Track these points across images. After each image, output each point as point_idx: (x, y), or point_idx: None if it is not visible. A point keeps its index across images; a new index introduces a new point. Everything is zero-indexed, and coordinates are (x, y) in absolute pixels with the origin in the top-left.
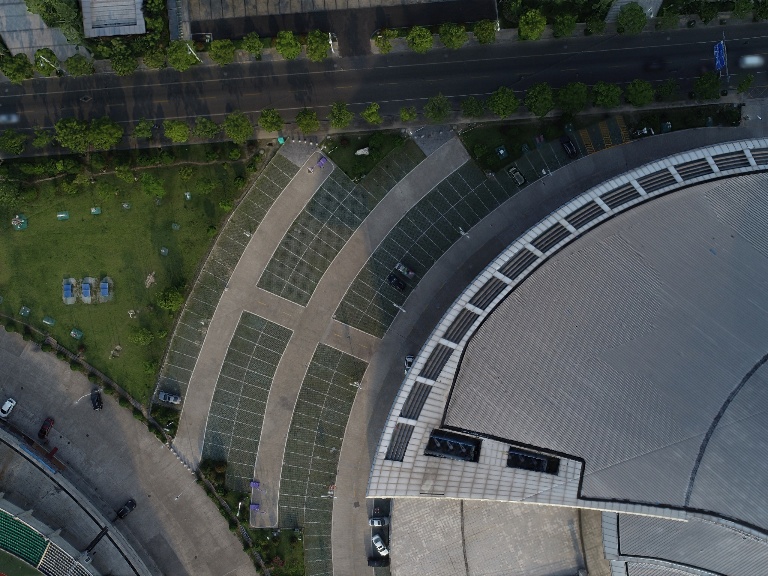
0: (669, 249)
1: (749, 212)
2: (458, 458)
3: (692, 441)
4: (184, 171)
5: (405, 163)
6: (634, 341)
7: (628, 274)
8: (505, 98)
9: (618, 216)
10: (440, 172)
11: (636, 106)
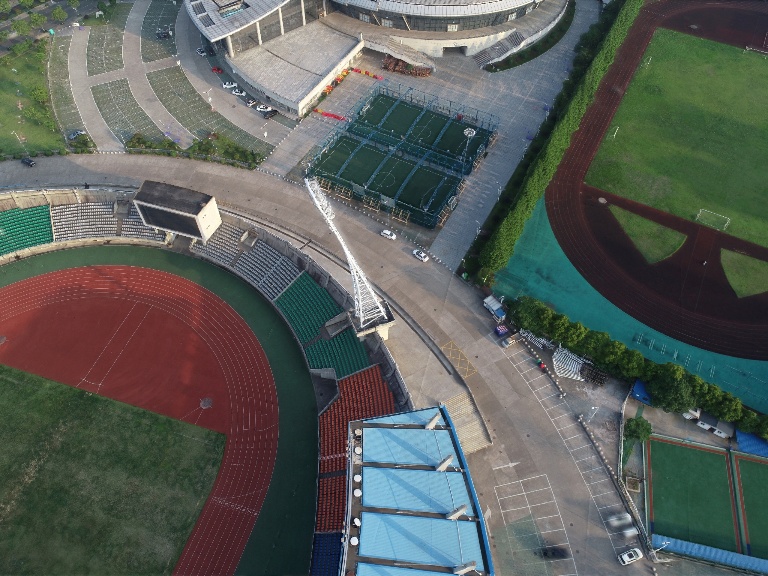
0: None
1: None
2: None
3: None
4: (4, 58)
5: (125, 10)
6: None
7: None
8: None
9: None
10: (146, 4)
11: None
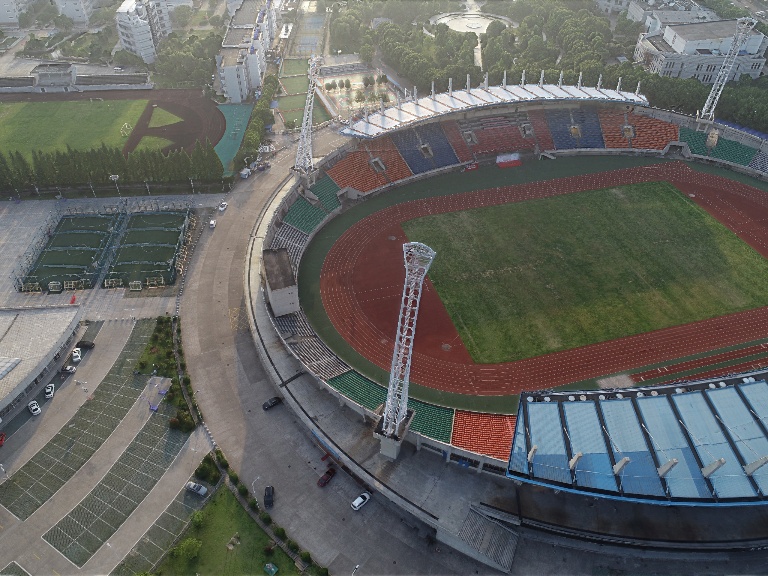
0: None
1: None
2: None
3: None
4: None
5: None
6: None
7: None
8: None
9: None
10: None
11: None
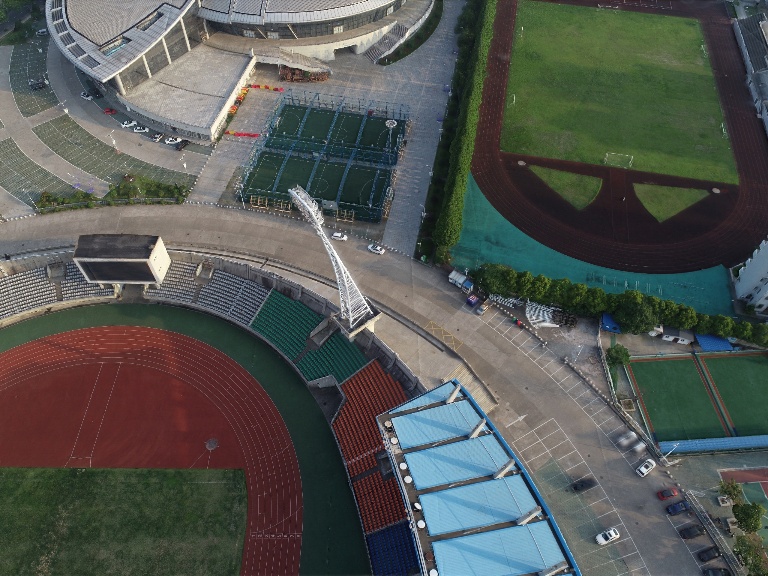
0: None
1: None
2: None
3: None
4: None
5: None
6: None
7: None
8: None
9: None
10: (6, 57)
11: None
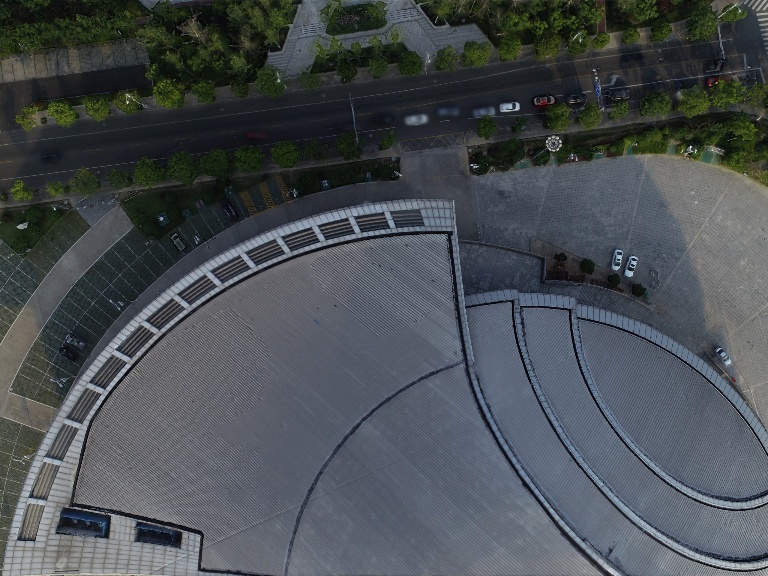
0: (276, 321)
1: (352, 280)
2: (92, 534)
3: (290, 513)
4: None
5: (70, 234)
6: (244, 414)
7: (239, 347)
8: (143, 170)
9: (229, 290)
10: (105, 241)
11: (295, 165)
